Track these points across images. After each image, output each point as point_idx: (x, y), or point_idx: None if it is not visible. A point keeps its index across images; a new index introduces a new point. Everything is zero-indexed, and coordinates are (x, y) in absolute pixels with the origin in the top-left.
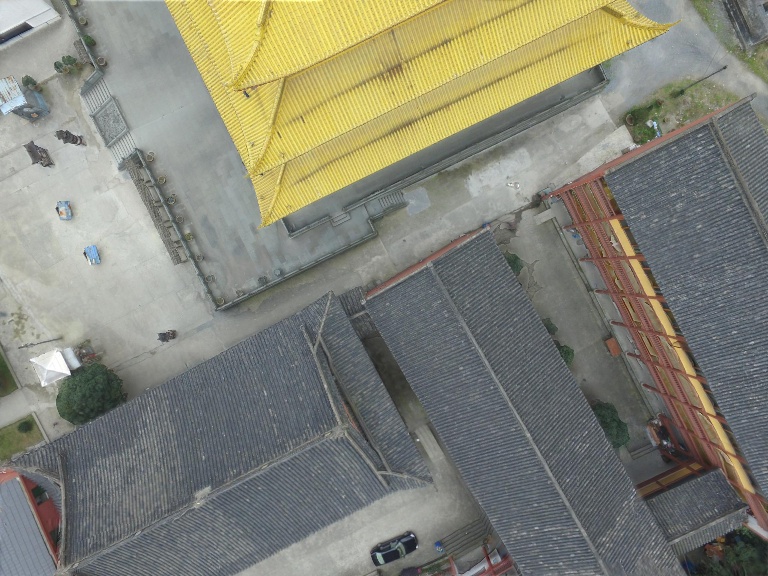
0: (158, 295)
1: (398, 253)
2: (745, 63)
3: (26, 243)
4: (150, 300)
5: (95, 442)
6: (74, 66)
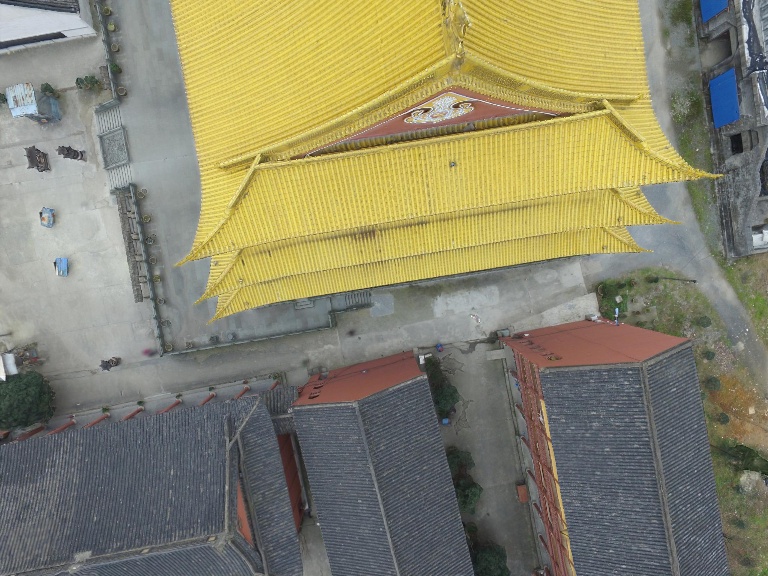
0: (114, 321)
1: (350, 348)
2: (723, 270)
3: (3, 235)
4: (105, 323)
5: (3, 466)
6: (96, 84)
